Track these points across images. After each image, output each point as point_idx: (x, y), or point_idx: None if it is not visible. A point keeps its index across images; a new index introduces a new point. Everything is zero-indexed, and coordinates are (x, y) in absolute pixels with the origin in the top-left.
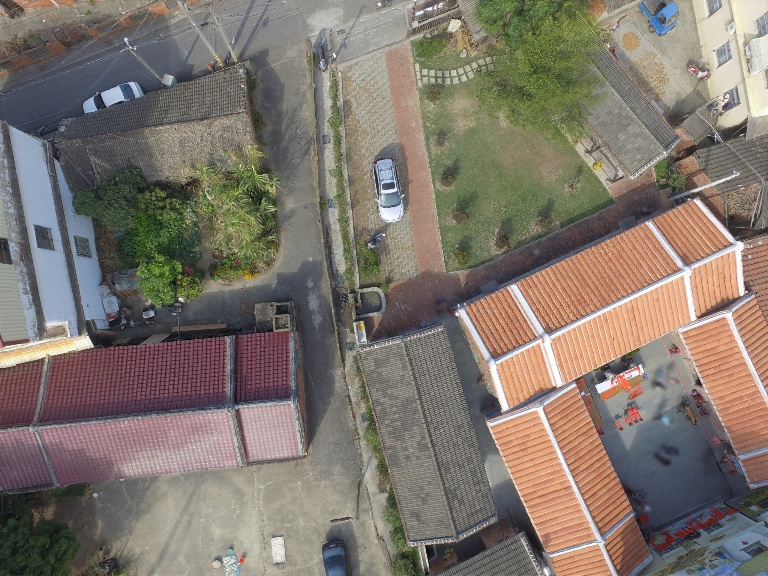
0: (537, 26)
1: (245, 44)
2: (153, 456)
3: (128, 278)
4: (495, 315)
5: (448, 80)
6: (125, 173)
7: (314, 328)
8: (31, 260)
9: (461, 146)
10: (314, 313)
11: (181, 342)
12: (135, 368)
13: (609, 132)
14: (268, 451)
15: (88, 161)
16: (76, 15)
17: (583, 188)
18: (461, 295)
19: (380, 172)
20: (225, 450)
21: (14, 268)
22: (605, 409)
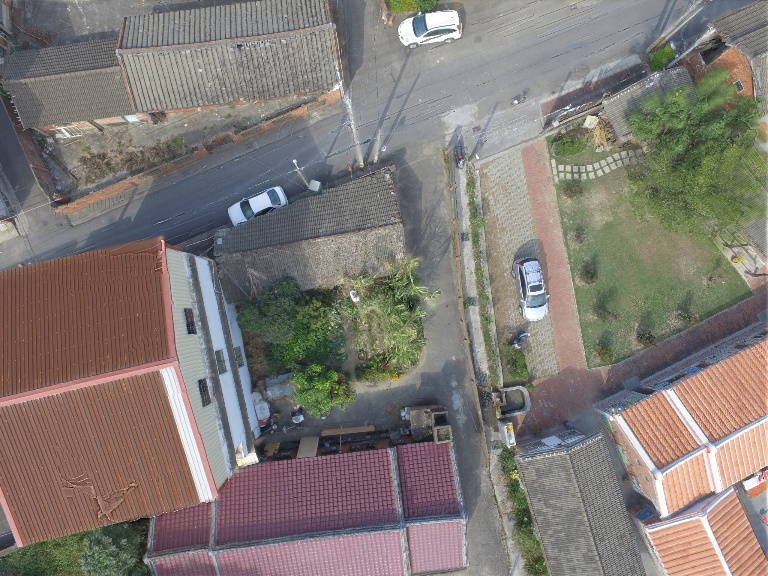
0: (712, 147)
1: (383, 143)
2: (322, 573)
3: (280, 385)
4: (653, 421)
5: (584, 175)
6: (283, 285)
7: (459, 428)
8: (221, 393)
9: (599, 241)
10: (459, 413)
11: (344, 455)
12: (302, 484)
13: (761, 234)
14: (432, 563)
15: (246, 273)
16: (217, 119)
17: (721, 281)
18: (603, 391)
19: (528, 274)
20: (392, 565)
21: (212, 406)
22: (750, 504)
